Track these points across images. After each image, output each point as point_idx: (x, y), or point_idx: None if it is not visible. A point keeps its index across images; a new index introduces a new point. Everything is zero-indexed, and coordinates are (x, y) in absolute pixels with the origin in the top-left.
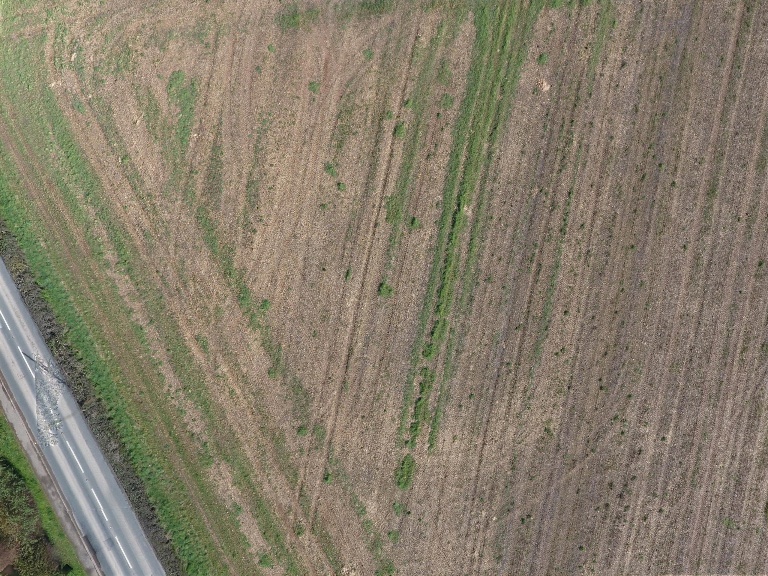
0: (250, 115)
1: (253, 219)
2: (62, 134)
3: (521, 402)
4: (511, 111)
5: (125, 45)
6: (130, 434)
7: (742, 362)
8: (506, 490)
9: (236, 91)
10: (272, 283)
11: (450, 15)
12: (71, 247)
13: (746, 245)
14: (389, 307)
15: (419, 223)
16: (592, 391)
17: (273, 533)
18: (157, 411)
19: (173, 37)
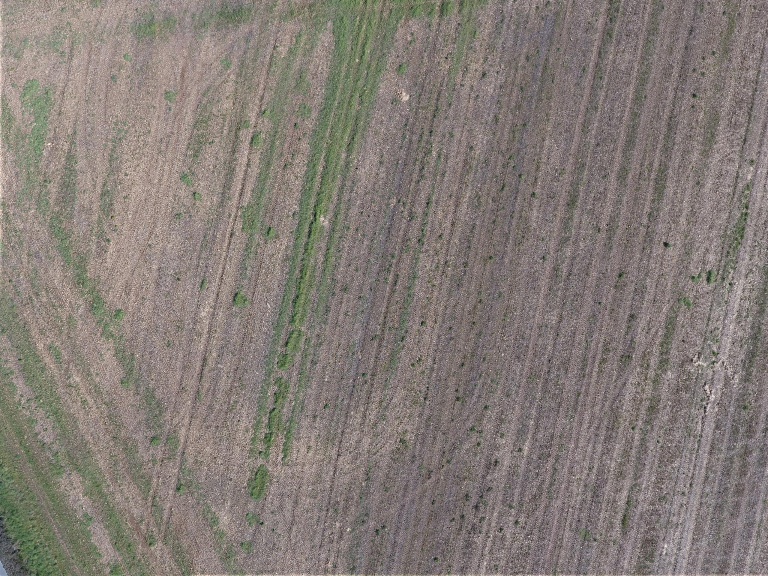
0: (105, 124)
1: (107, 228)
2: None
3: (376, 413)
4: (369, 121)
5: None
6: None
7: (601, 373)
8: (361, 501)
9: (91, 100)
10: (126, 293)
11: (309, 25)
12: None
13: (606, 256)
14: (244, 317)
15: (275, 233)
16: (448, 402)
17: (125, 543)
18: (8, 421)
19: (28, 46)
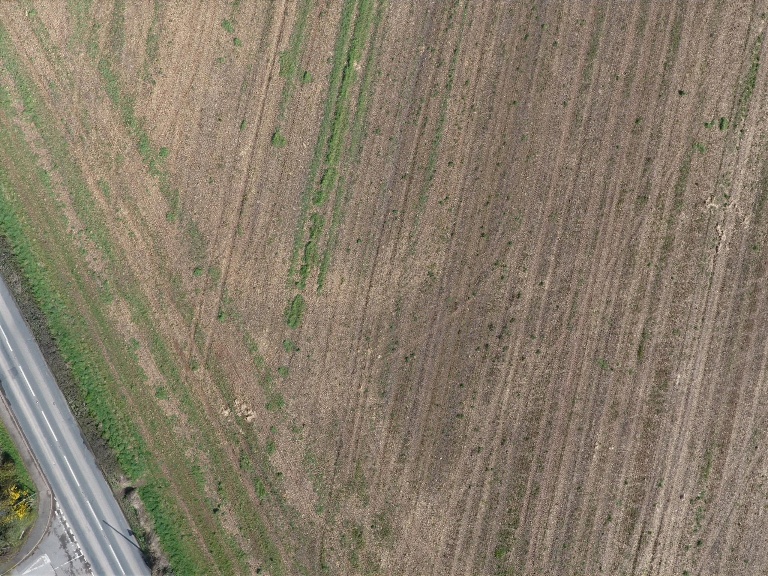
0: None
1: (153, 71)
2: None
3: (406, 247)
4: None
5: None
6: (34, 271)
7: (618, 213)
8: (391, 330)
9: None
10: (170, 132)
11: None
12: None
13: (624, 103)
14: (282, 156)
15: (311, 77)
16: (474, 238)
17: (169, 367)
18: (60, 250)
19: None
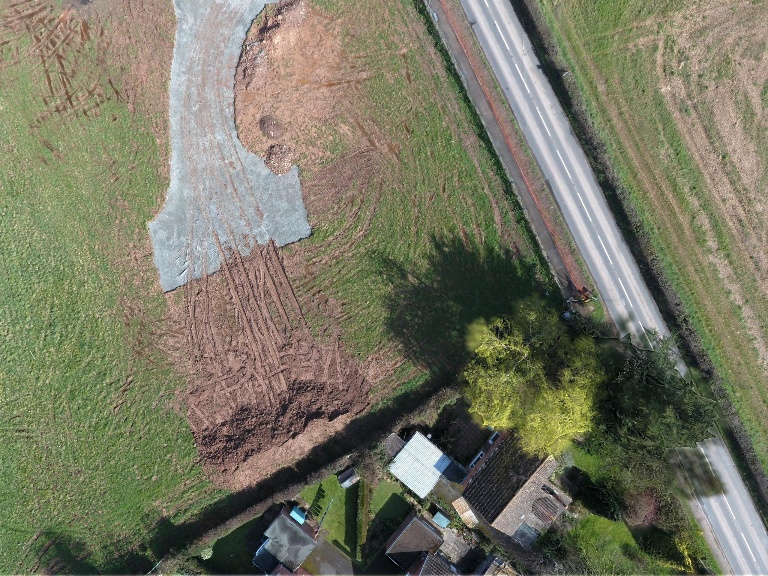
0: None
1: None
2: (672, 134)
3: None
4: None
5: (725, 55)
6: (733, 400)
7: None
8: None
9: None
10: None
11: None
12: (680, 234)
13: None
14: None
15: None
16: None
17: None
18: (753, 381)
19: (766, 49)
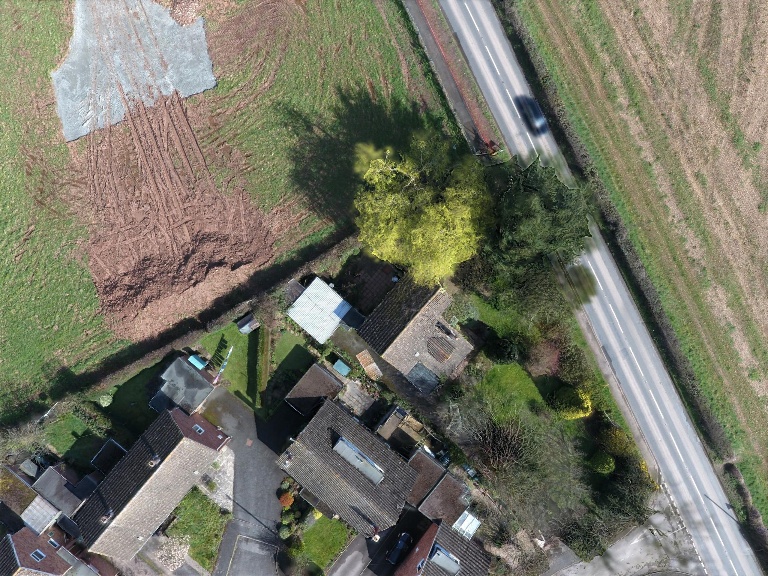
0: None
1: (747, 70)
2: None
3: None
4: None
5: None
6: (642, 257)
7: None
8: None
9: None
10: (763, 128)
11: None
12: (590, 90)
13: None
14: None
15: None
16: None
17: (761, 350)
18: (663, 238)
19: None
